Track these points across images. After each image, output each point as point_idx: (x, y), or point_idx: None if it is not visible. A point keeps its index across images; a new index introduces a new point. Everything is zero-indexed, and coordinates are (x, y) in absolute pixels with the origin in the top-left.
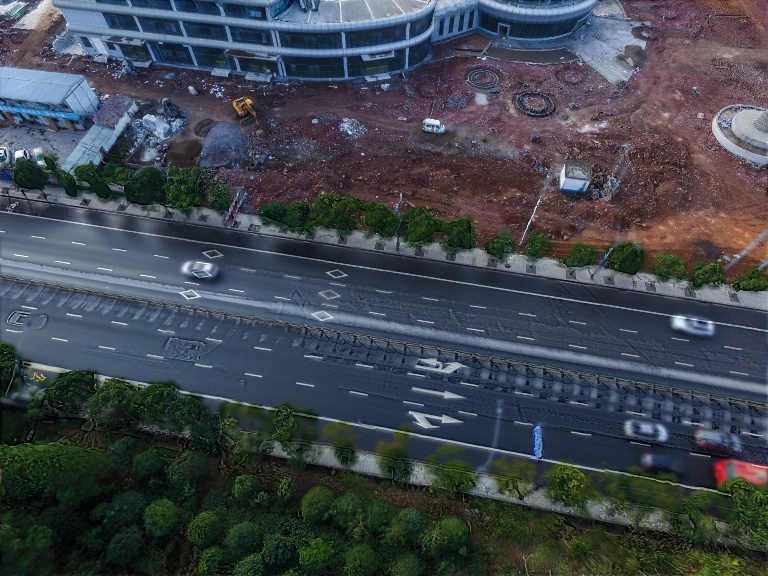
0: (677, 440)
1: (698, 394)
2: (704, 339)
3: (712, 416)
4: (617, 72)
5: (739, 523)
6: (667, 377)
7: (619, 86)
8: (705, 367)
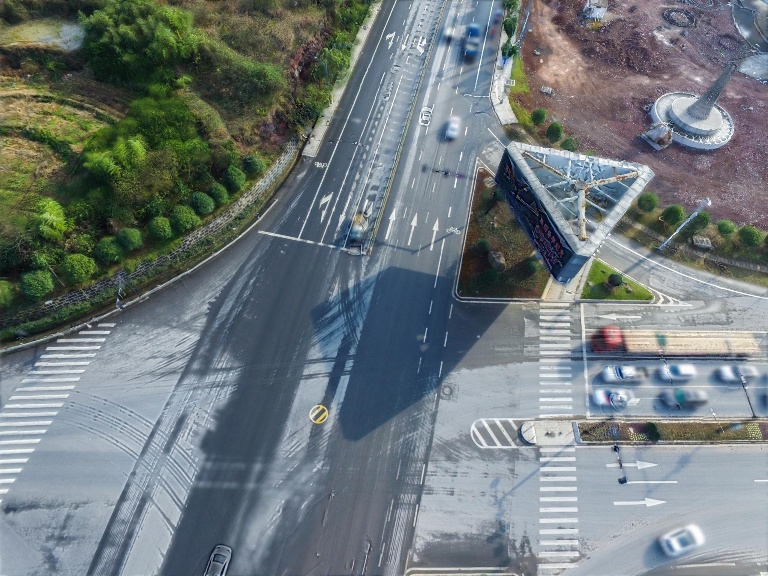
0: (417, 3)
1: (441, 14)
2: (475, 27)
3: (429, 16)
4: (751, 68)
5: (380, 8)
6: (450, 8)
7: (727, 62)
8: (457, 22)
